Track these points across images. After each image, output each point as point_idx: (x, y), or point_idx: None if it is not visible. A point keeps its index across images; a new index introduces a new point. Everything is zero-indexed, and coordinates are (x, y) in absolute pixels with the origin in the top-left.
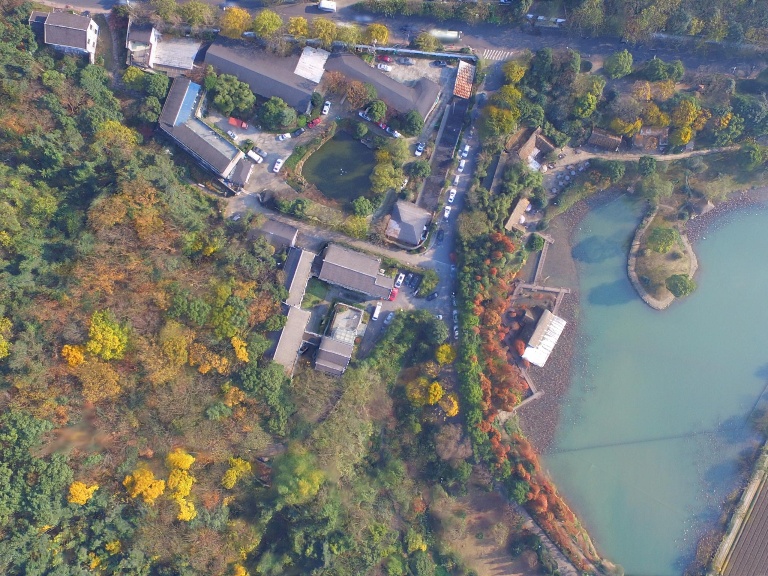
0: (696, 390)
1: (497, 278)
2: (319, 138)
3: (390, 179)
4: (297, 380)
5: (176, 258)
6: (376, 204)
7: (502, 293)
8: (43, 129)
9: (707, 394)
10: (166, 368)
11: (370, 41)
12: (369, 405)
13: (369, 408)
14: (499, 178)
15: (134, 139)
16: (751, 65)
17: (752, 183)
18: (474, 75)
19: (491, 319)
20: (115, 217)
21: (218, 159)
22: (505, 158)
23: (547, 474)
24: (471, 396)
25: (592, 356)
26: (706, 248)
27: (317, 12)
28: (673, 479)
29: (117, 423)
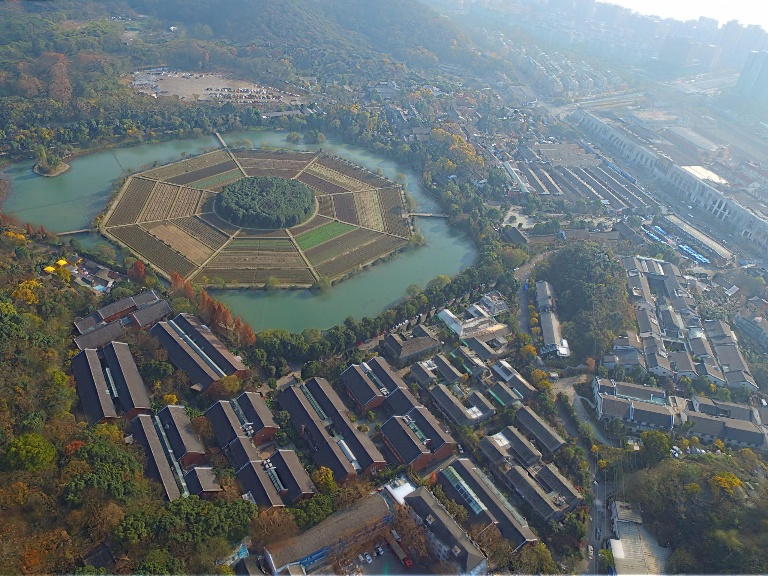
0: (79, 190)
1: None
2: None
3: None
4: None
5: None
6: None
7: None
8: None
9: (85, 190)
10: None
11: None
12: None
13: None
14: None
15: None
16: None
17: (90, 149)
18: None
19: None
20: None
21: None
22: None
23: None
24: None
25: None
26: (73, 163)
27: None
28: None
29: None
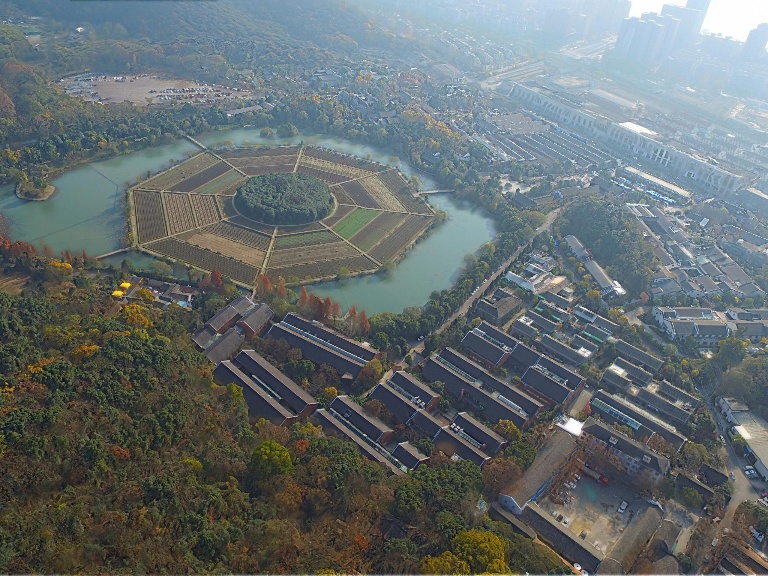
0: (82, 211)
1: None
2: None
3: None
4: None
5: None
6: None
7: None
8: None
9: (89, 210)
10: None
11: None
12: None
13: None
14: None
15: None
16: None
17: (64, 167)
18: None
19: None
20: None
21: None
22: None
23: None
24: None
25: None
26: (56, 183)
27: None
28: (90, 231)
29: None
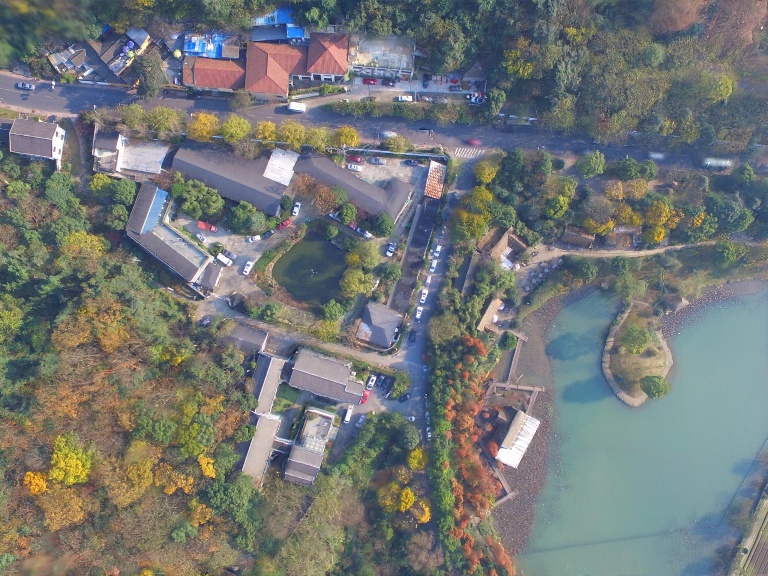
0: (672, 487)
1: (469, 382)
2: (289, 241)
3: (360, 285)
4: (267, 487)
5: (143, 370)
6: (347, 307)
7: (475, 392)
8: (6, 247)
9: (683, 491)
10: (131, 491)
11: (339, 145)
12: (341, 509)
13: (341, 511)
14: (471, 278)
15: (101, 247)
16: (725, 160)
17: (727, 277)
18: (445, 175)
19: (463, 424)
20: (79, 338)
21: (186, 267)
22: (477, 258)
23: (522, 575)
24: (443, 503)
25: (567, 454)
26: (681, 343)
27: (286, 113)
28: None
29: (80, 550)
